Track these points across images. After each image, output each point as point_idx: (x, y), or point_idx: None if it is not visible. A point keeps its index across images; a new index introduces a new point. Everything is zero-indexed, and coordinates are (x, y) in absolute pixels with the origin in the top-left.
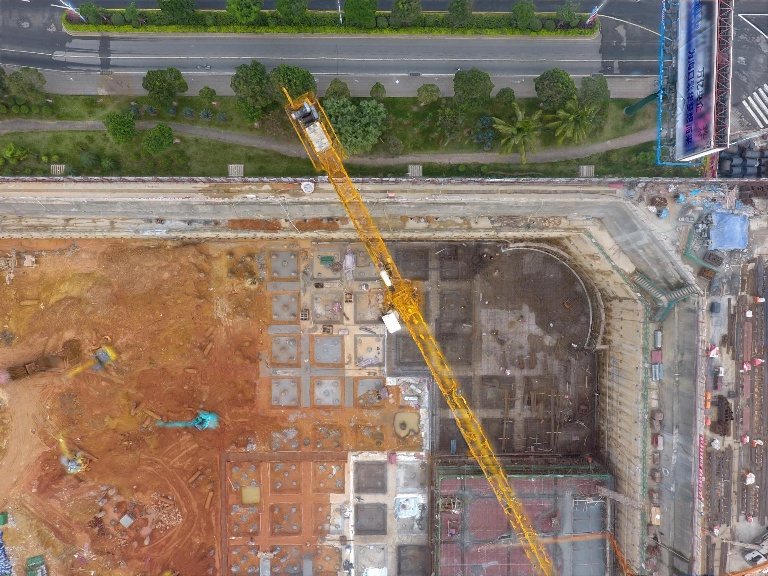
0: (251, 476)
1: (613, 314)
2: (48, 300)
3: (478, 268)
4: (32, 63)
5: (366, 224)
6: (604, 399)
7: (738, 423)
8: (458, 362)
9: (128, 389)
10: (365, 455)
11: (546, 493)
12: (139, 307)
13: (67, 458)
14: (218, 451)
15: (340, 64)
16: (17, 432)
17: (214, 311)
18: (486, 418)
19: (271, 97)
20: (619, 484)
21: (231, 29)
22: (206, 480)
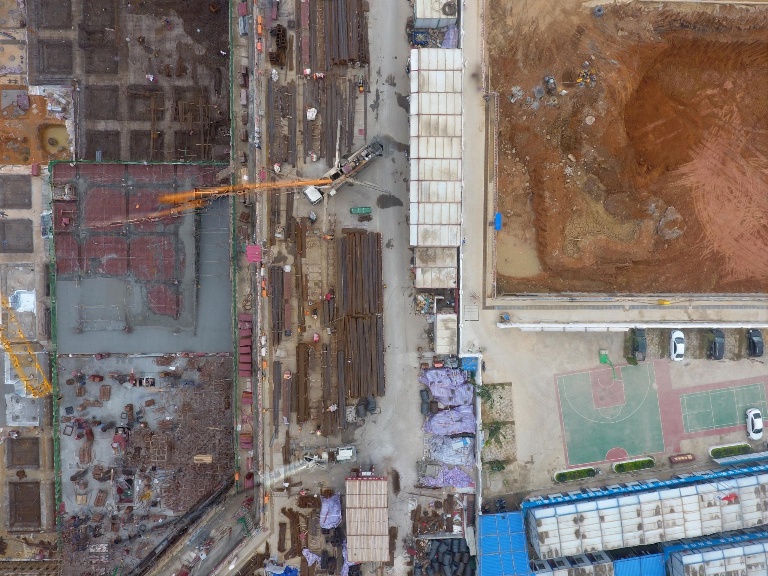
0: None
1: None
2: None
3: None
4: None
5: None
6: None
7: (301, 57)
8: (105, 72)
9: None
10: (9, 169)
11: (166, 183)
12: None
13: None
14: None
15: None
16: None
17: None
18: (133, 129)
19: None
20: None
21: None
22: None
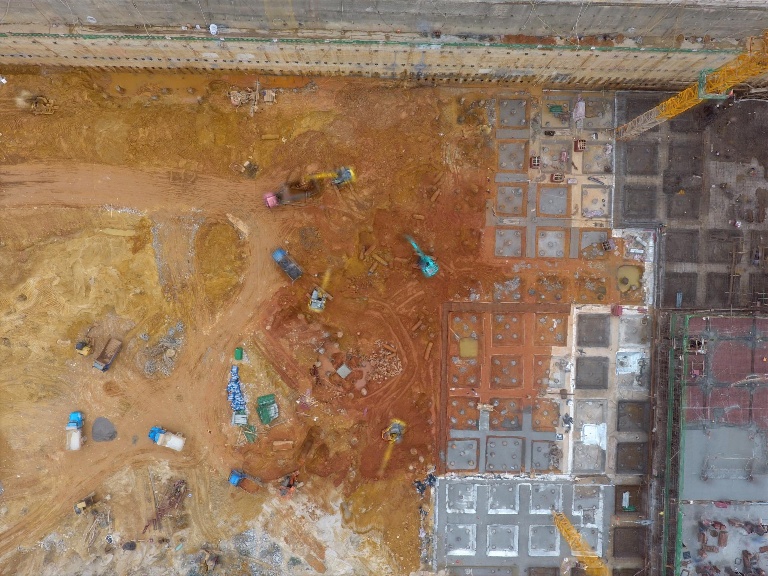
0: (471, 328)
1: None
2: (289, 134)
3: (710, 119)
4: None
5: (642, 43)
6: None
7: None
8: (684, 216)
9: (367, 226)
10: (588, 308)
11: None
12: (385, 140)
13: (304, 294)
14: (441, 300)
15: None
16: (255, 267)
17: (443, 157)
18: (712, 272)
19: None
20: None
21: None
22: (425, 331)
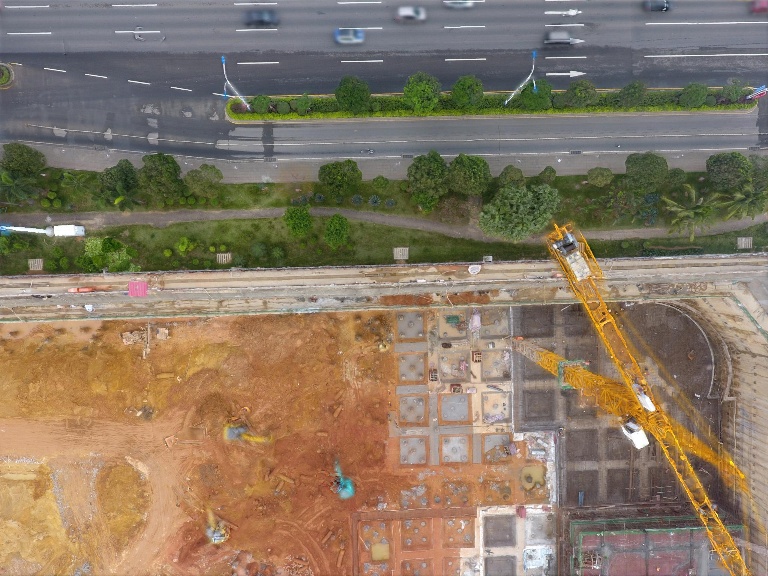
0: (381, 534)
1: (742, 367)
2: (184, 372)
3: None
4: (195, 152)
5: (517, 296)
6: (729, 448)
7: None
8: (583, 415)
9: (267, 458)
10: (494, 509)
11: (683, 545)
12: (278, 378)
13: (208, 528)
14: (350, 511)
15: (502, 144)
16: (158, 504)
17: (343, 374)
18: (612, 469)
19: (448, 186)
20: (754, 534)
21: (396, 114)
22: (337, 539)
